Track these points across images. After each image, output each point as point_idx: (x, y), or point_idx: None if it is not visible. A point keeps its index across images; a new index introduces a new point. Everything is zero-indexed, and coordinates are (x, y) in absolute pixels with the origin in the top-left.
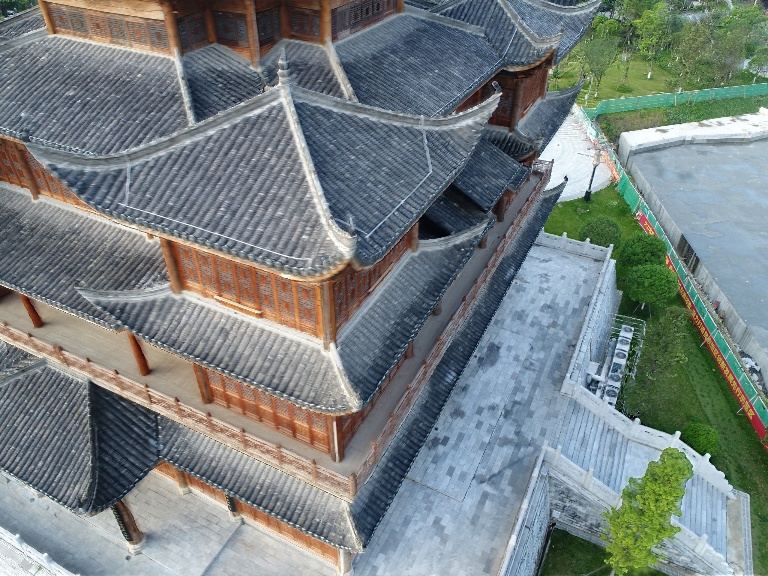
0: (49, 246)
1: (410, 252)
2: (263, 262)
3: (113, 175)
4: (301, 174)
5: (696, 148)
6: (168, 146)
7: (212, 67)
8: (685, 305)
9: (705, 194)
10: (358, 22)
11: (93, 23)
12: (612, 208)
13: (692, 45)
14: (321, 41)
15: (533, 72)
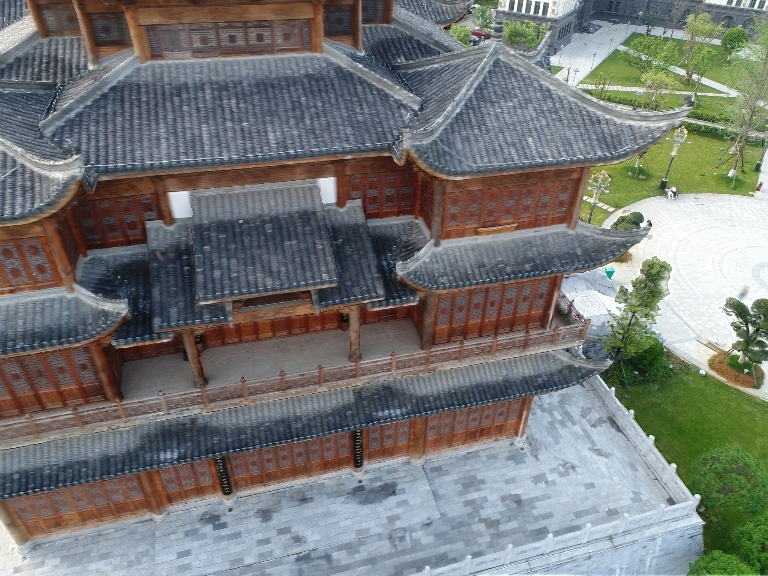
0: None
1: (61, 290)
2: None
3: None
4: None
5: None
6: None
7: (55, 54)
8: None
9: None
10: (210, 47)
11: None
12: None
13: None
14: None
15: None
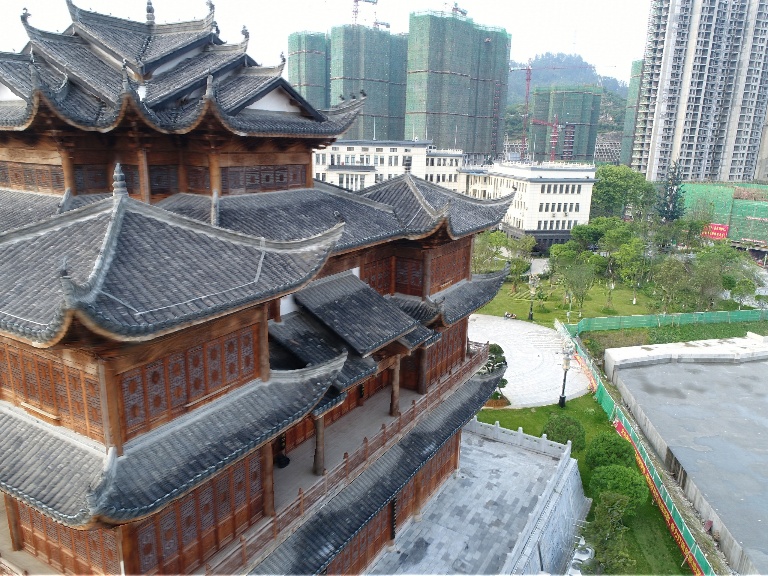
0: None
1: (258, 381)
2: (17, 330)
3: None
4: None
5: (684, 366)
6: None
7: None
8: (664, 518)
9: (693, 409)
10: (256, 185)
11: (13, 174)
12: (588, 415)
13: (668, 273)
14: (211, 193)
15: (433, 241)
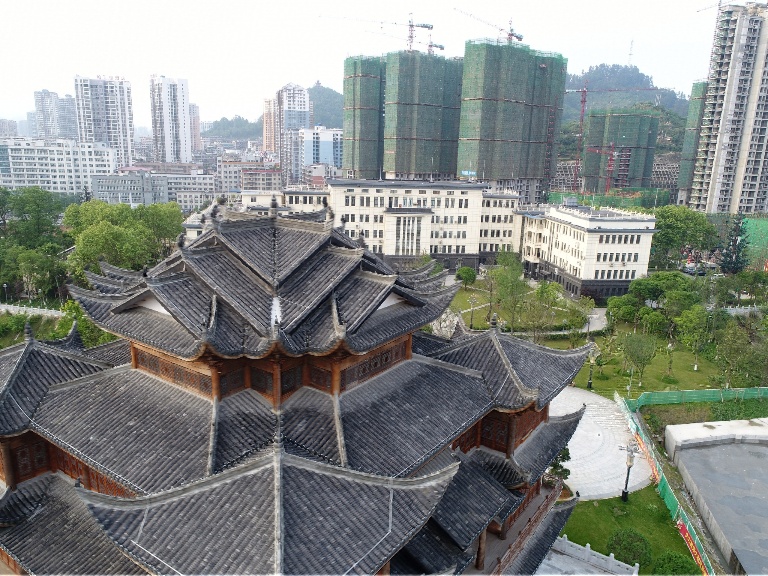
0: (82, 543)
1: None
2: None
3: (134, 515)
4: (271, 537)
5: (748, 448)
6: (181, 494)
7: (241, 411)
8: None
9: (758, 503)
10: (366, 374)
11: (163, 367)
12: (651, 512)
13: (732, 346)
14: (331, 392)
15: (521, 414)
